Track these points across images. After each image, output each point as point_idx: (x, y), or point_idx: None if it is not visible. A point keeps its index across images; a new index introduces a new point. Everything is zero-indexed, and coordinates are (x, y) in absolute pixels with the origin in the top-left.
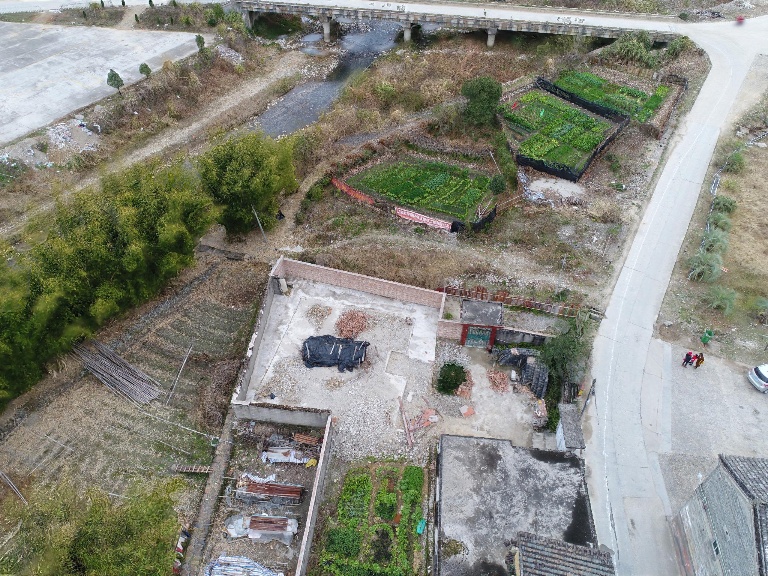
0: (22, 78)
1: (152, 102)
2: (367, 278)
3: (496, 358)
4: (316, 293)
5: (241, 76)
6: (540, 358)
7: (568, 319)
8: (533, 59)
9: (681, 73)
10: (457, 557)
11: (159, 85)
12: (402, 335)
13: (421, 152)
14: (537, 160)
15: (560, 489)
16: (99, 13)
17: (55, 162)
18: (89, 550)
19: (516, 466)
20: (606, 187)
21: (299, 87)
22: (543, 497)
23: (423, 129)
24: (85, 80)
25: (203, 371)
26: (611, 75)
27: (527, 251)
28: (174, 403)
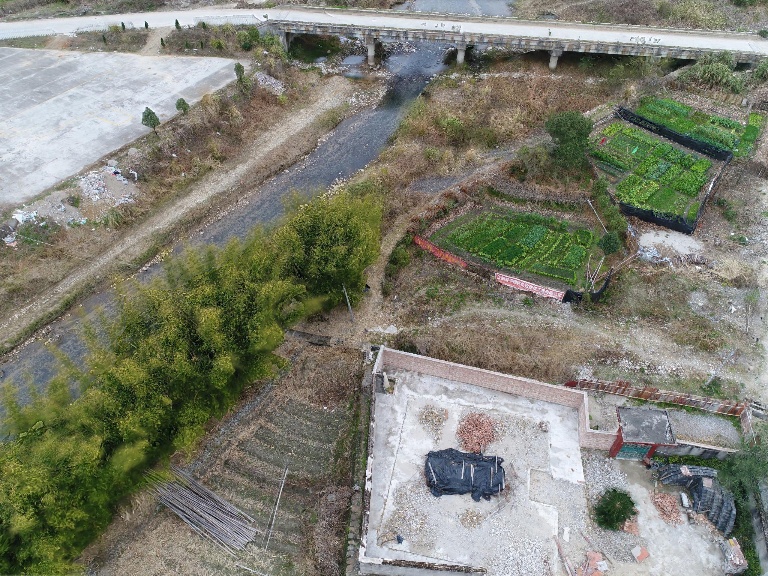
0: (42, 116)
1: (191, 142)
2: (488, 373)
3: (657, 475)
4: (425, 390)
5: (284, 107)
6: (718, 479)
7: (729, 418)
8: (603, 83)
9: None
10: None
11: (198, 122)
12: (540, 447)
13: (507, 200)
14: None
15: None
16: (120, 37)
17: (89, 218)
18: None
19: None
20: (728, 241)
21: (349, 119)
22: None
23: (505, 172)
24: (113, 117)
25: (303, 499)
26: (695, 101)
27: (659, 327)
28: (275, 547)
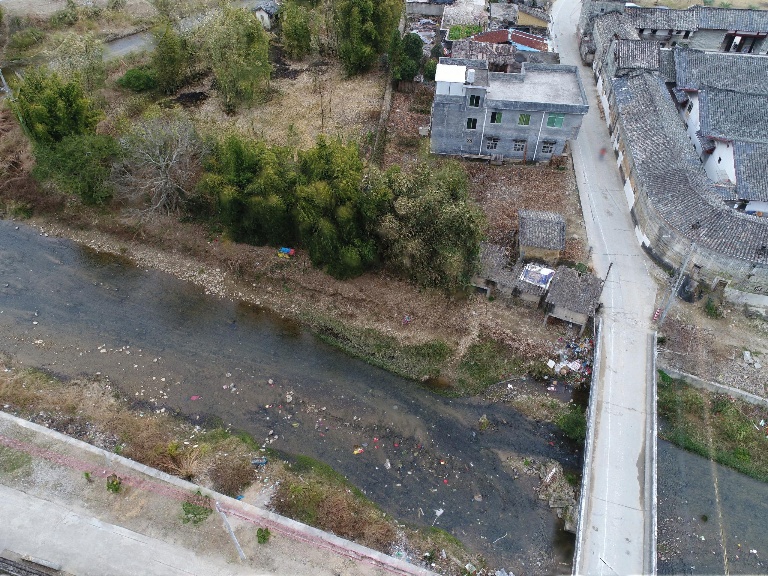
0: None
1: None
2: None
3: None
4: None
5: None
6: None
7: None
8: None
9: None
10: None
11: None
12: None
13: None
14: None
15: None
16: None
17: None
18: None
19: None
20: None
21: None
22: None
23: None
24: None
25: None
26: None
27: None
28: None
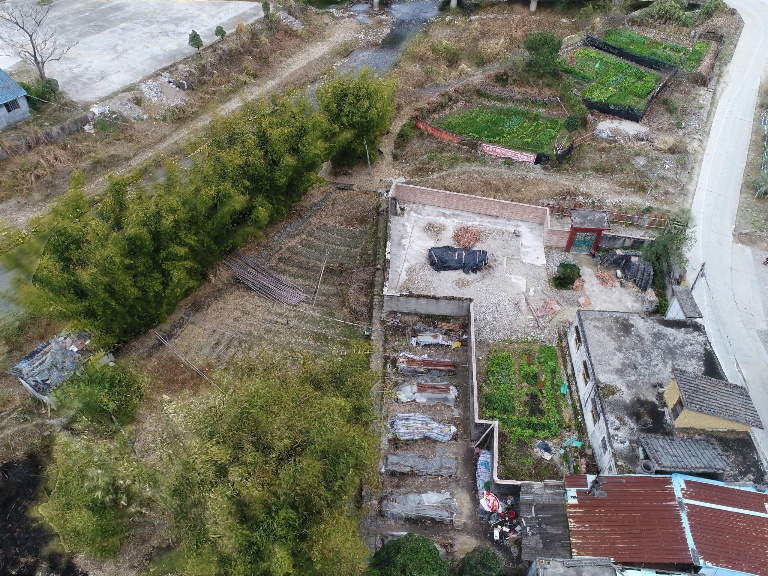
0: (101, 42)
1: (228, 62)
2: (475, 198)
3: (600, 261)
4: (427, 214)
5: (304, 40)
6: (642, 257)
7: (656, 230)
8: (576, 22)
9: (716, 30)
10: (615, 397)
11: (234, 46)
12: (514, 244)
13: (492, 100)
14: (601, 104)
15: (689, 347)
16: None
17: (150, 115)
18: (317, 388)
19: (648, 331)
20: (668, 125)
21: (359, 50)
22: (676, 353)
23: (491, 80)
24: (161, 43)
25: (339, 279)
26: (651, 34)
27: (608, 177)
28: (320, 304)
